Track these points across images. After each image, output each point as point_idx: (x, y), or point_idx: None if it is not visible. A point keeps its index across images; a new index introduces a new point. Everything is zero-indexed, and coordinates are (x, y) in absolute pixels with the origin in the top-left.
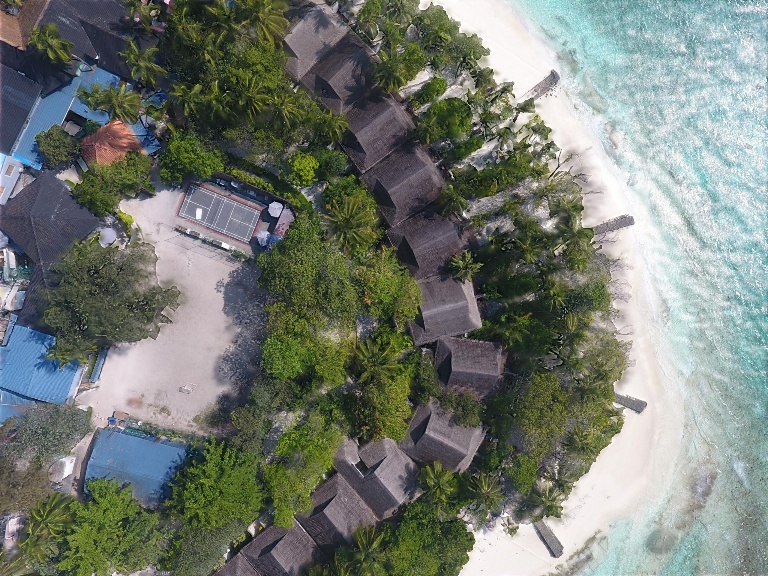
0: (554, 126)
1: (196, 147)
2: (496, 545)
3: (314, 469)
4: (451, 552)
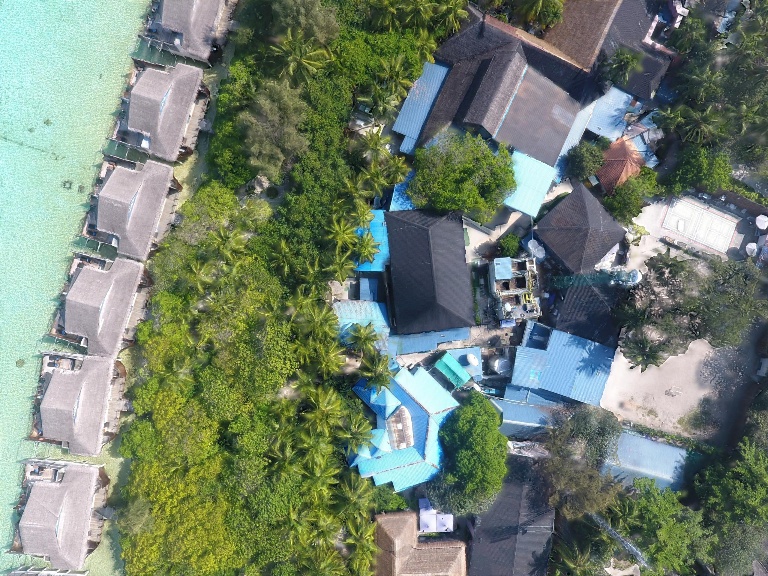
0: None
1: (728, 163)
2: None
3: None
4: None
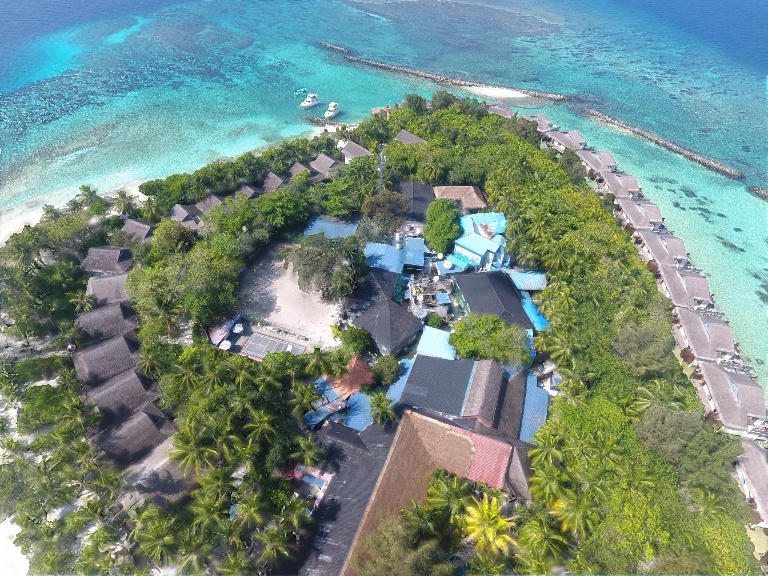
0: None
1: None
2: None
3: None
4: None
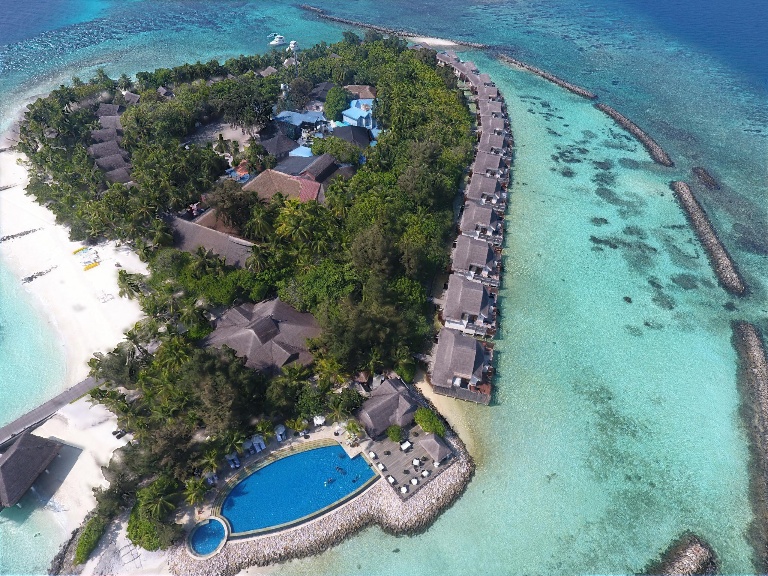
0: (8, 178)
1: None
2: None
3: None
4: None
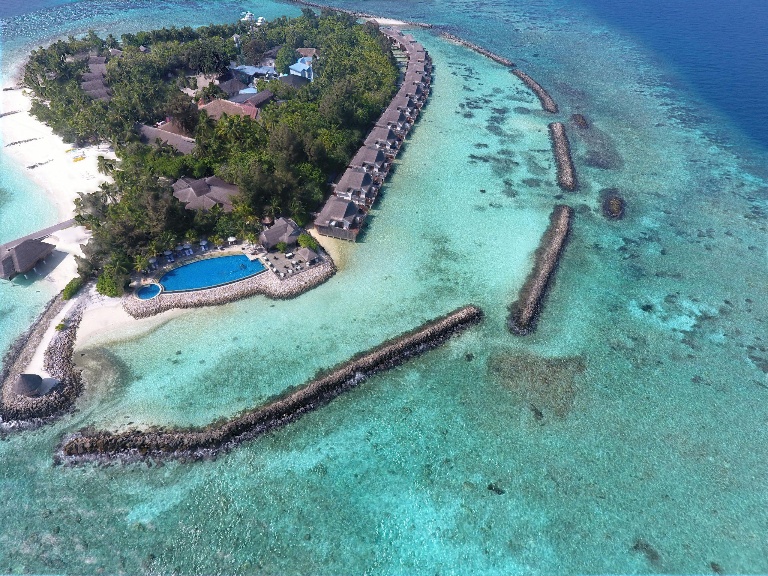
0: None
1: None
2: None
3: None
4: None
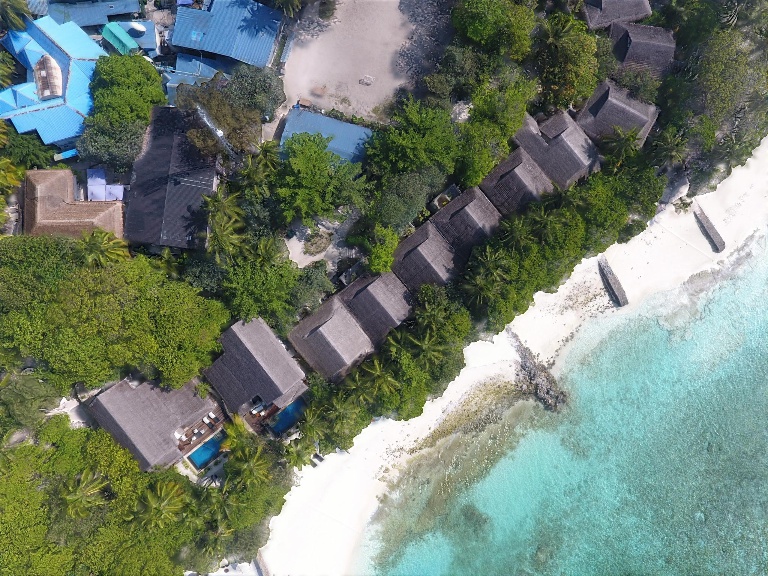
0: None
1: None
2: (661, 238)
3: (514, 112)
4: (643, 197)
